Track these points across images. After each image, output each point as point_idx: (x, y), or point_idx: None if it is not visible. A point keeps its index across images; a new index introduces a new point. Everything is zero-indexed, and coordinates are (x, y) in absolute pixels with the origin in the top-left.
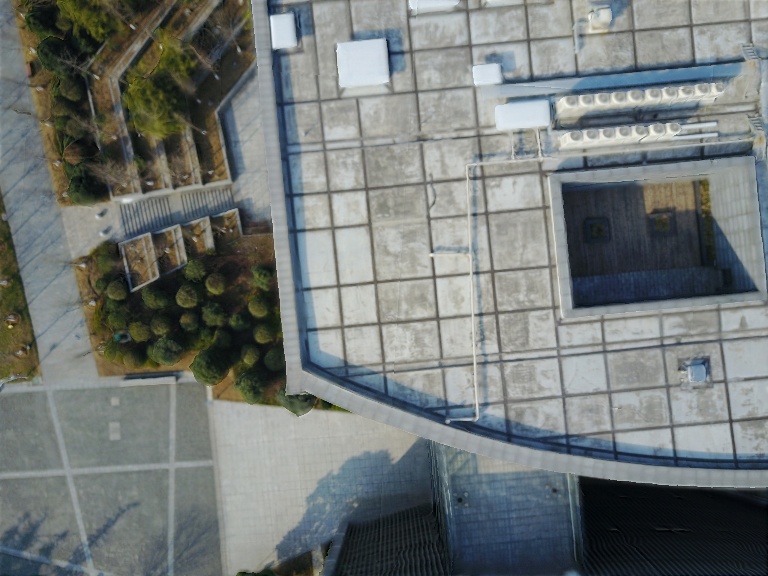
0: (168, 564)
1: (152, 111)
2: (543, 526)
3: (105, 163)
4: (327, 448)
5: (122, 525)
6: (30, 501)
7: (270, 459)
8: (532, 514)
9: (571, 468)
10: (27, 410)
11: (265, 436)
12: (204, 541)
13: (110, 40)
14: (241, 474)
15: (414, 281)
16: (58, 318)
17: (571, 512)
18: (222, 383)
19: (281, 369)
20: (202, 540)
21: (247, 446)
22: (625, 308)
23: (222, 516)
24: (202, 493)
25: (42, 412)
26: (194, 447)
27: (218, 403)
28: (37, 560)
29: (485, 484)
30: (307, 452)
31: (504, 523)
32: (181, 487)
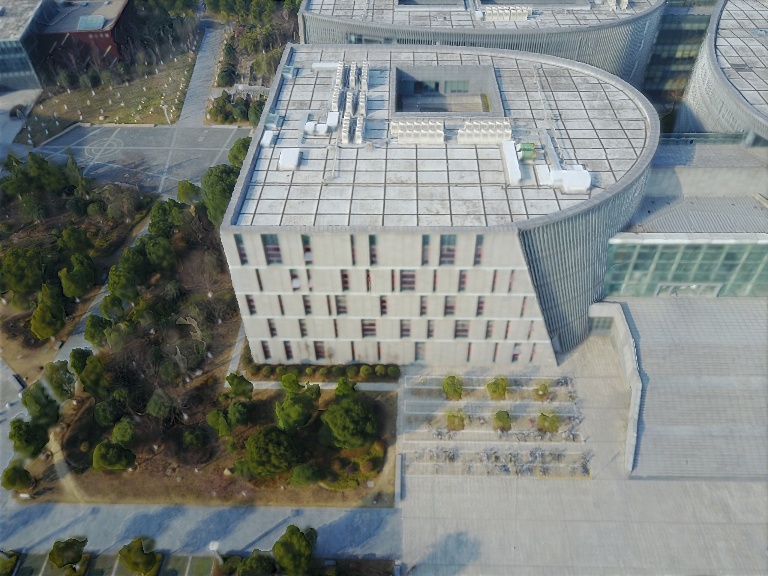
0: None
1: (263, 60)
2: None
3: (237, 76)
4: None
5: None
6: (147, 155)
7: None
8: None
9: (391, 25)
10: None
11: None
12: None
13: (254, 52)
14: None
15: (347, 4)
16: None
17: None
18: None
19: None
20: None
21: None
22: (416, 5)
23: None
24: None
25: None
26: None
27: None
28: (138, 171)
29: None
30: None
31: None
32: (224, 156)
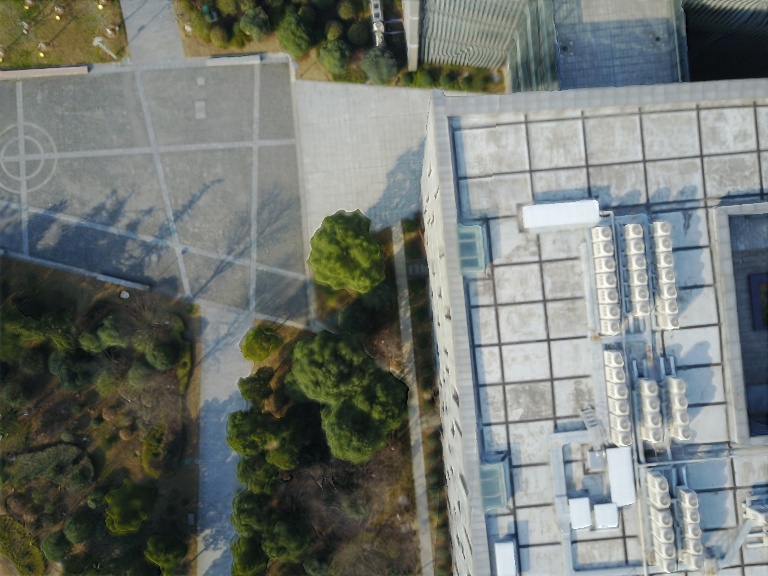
0: (251, 239)
1: None
2: (647, 73)
3: None
4: (407, 126)
5: (207, 201)
6: (117, 178)
7: (351, 137)
8: (636, 62)
9: None
10: (115, 89)
11: (347, 115)
12: (286, 218)
13: None
14: (323, 152)
15: None
16: (146, 0)
17: (677, 50)
18: (305, 62)
19: (364, 43)
20: (284, 217)
21: (329, 124)
22: None
23: (304, 194)
24: (285, 171)
25: (130, 91)
26: (277, 126)
27: (301, 83)
28: (124, 234)
29: (590, 32)
30: (388, 129)
31: (609, 70)
32: (264, 165)
